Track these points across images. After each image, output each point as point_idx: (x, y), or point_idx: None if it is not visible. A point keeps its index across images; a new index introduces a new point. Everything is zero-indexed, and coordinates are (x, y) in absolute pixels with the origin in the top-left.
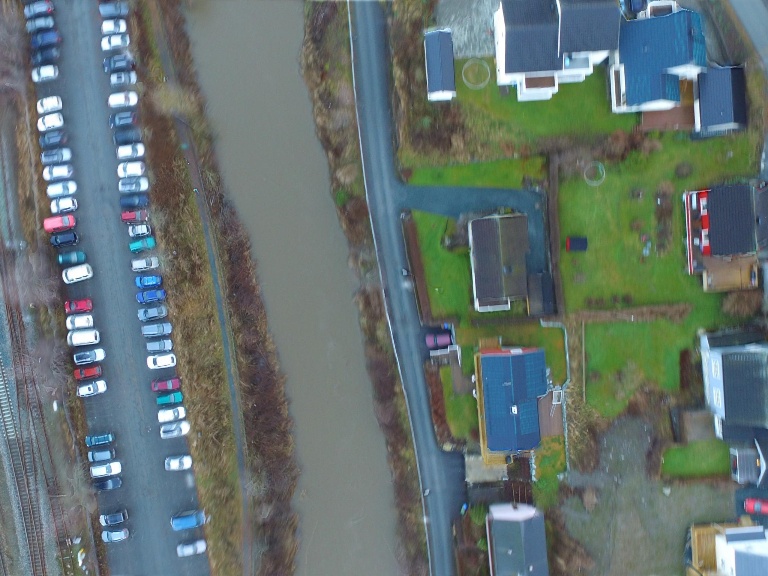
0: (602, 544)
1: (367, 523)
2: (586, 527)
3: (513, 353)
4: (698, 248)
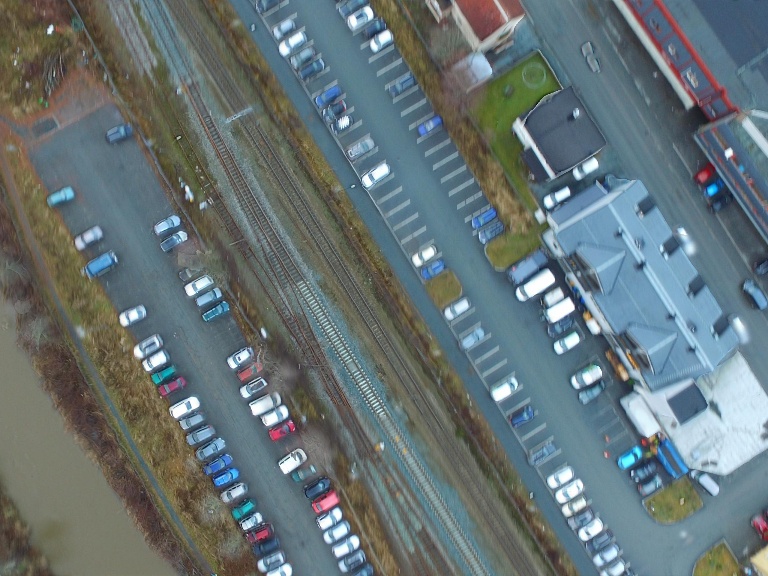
0: None
1: None
2: None
3: None
4: None
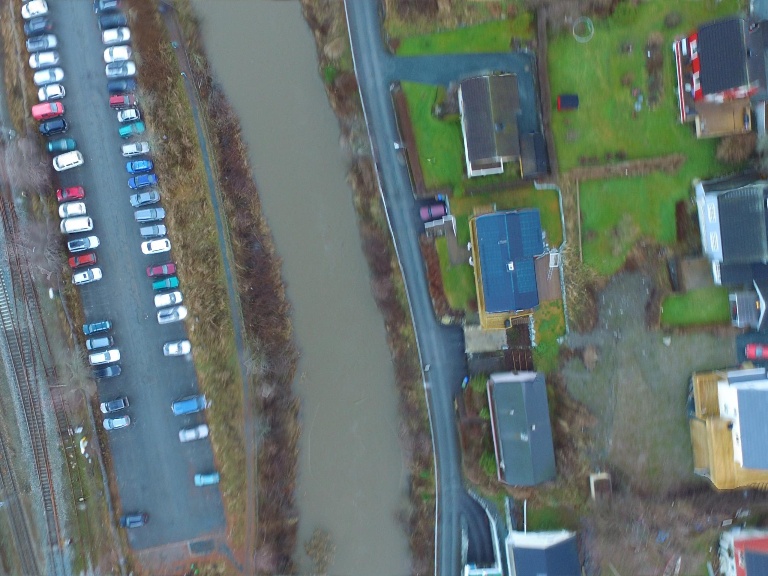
0: (604, 400)
1: (369, 404)
2: (588, 386)
3: (508, 213)
4: (690, 94)
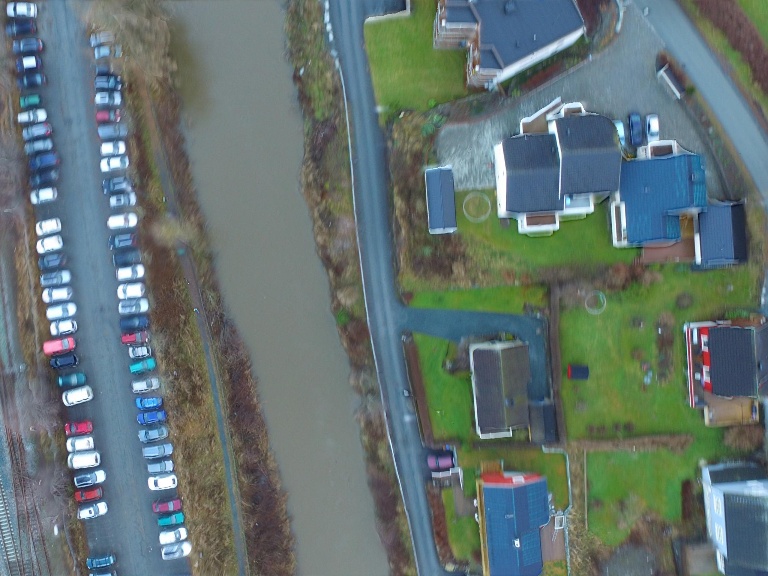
0: None
1: None
2: None
3: (515, 483)
4: (699, 383)
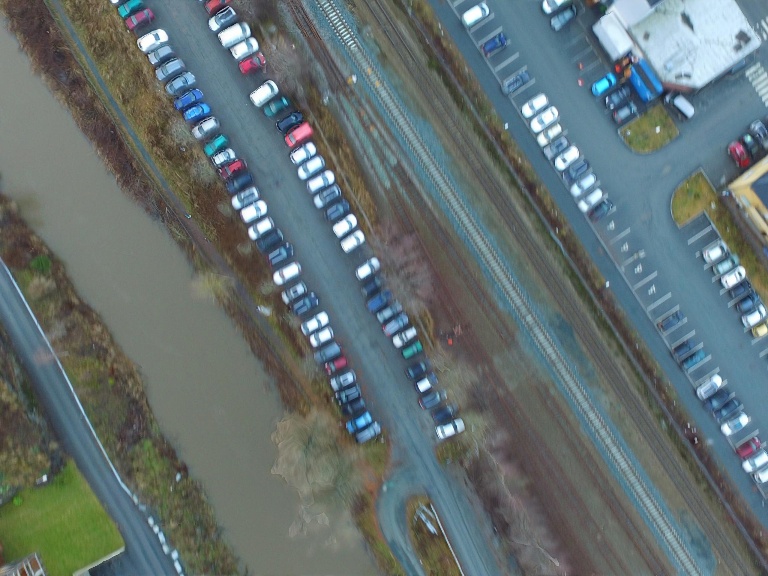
0: None
1: None
2: None
3: None
4: None
